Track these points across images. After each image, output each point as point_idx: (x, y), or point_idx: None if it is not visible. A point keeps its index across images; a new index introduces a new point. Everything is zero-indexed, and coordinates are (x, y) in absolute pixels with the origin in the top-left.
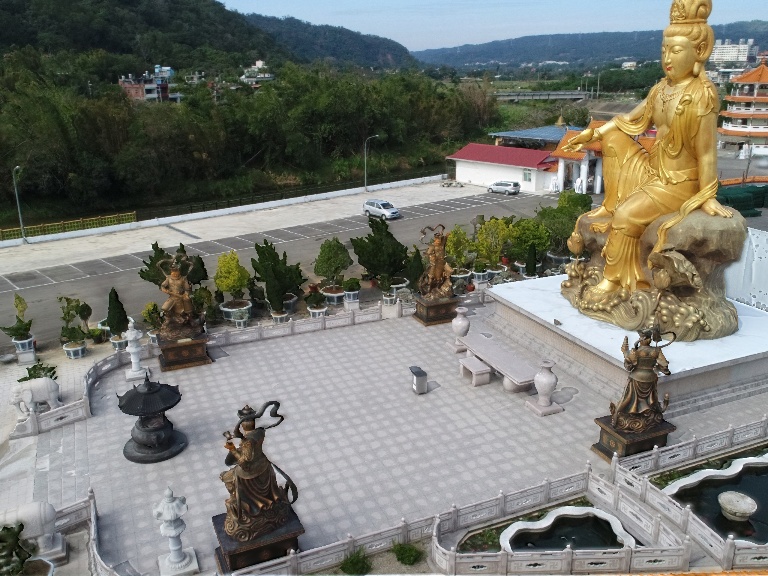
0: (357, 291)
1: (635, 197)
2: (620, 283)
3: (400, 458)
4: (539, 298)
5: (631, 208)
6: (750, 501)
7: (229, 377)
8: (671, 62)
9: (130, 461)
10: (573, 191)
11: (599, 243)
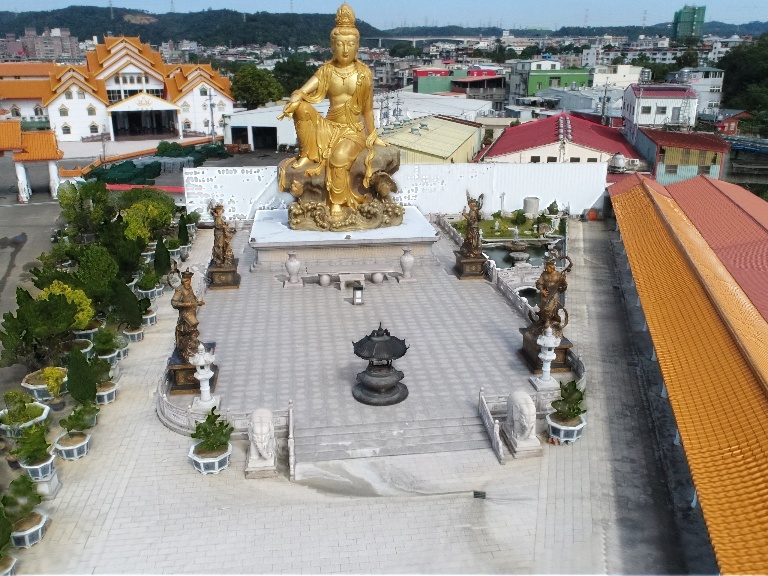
0: (155, 287)
1: (345, 143)
2: (347, 204)
3: (446, 319)
4: (295, 235)
5: (348, 151)
6: (524, 263)
7: (263, 362)
8: (348, 52)
9: (400, 403)
10: (69, 183)
11: (315, 183)
